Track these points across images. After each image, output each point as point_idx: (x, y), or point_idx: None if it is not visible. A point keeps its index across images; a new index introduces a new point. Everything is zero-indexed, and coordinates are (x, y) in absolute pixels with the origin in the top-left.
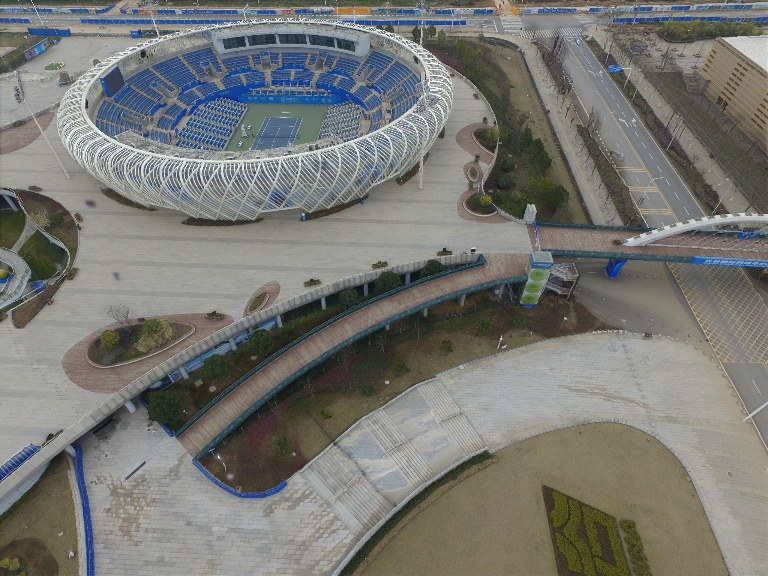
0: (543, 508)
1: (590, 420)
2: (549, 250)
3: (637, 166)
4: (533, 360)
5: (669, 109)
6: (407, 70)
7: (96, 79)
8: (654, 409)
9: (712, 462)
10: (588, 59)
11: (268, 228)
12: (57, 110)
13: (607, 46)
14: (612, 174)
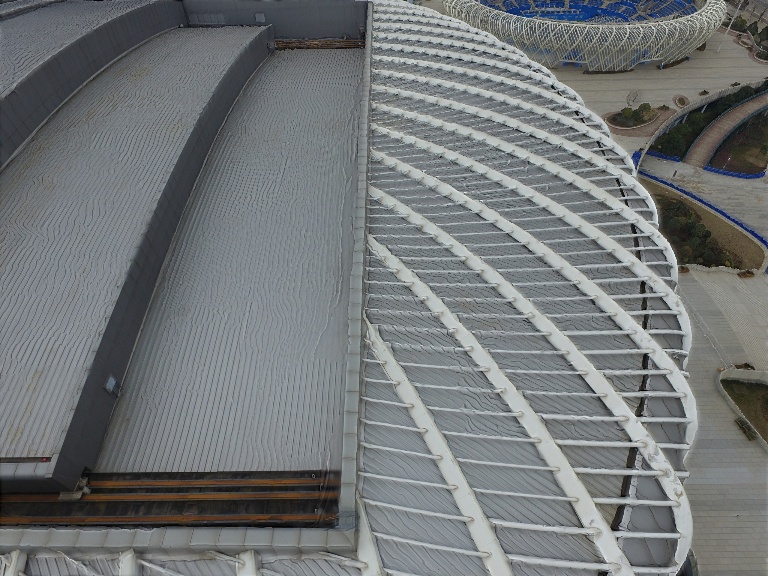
0: None
1: None
2: None
3: None
4: None
5: None
6: None
7: None
8: None
9: None
10: None
11: (642, 73)
12: None
13: None
14: None
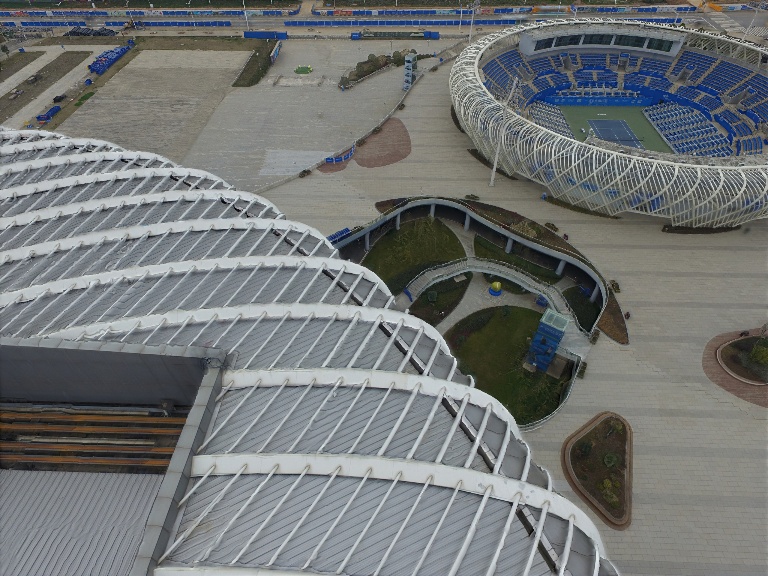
0: None
1: None
2: None
3: None
4: None
5: None
6: (744, 70)
7: None
8: None
9: None
10: None
11: (756, 235)
12: (398, 115)
13: None
14: None
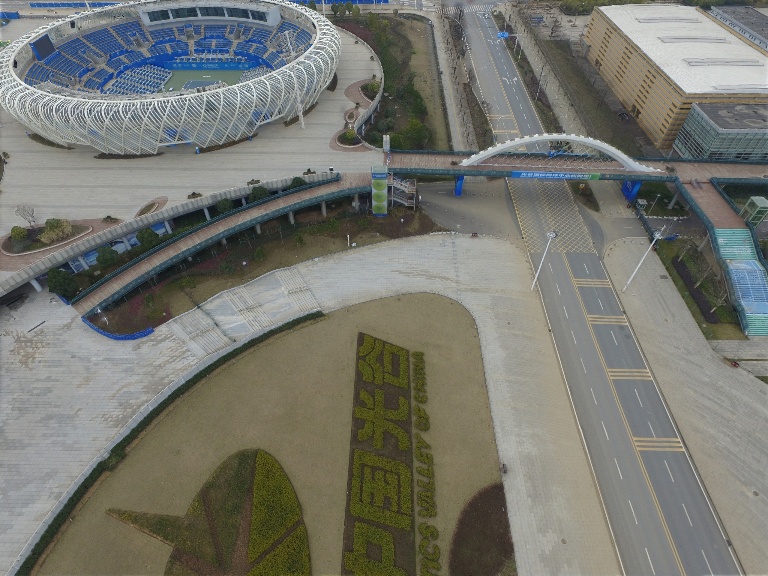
0: (355, 346)
1: (410, 292)
2: (395, 169)
3: (506, 114)
4: (376, 254)
5: (548, 69)
6: (309, 36)
7: (26, 44)
8: (463, 284)
9: (497, 316)
10: (491, 30)
11: (167, 159)
12: None
13: (506, 18)
14: (482, 120)
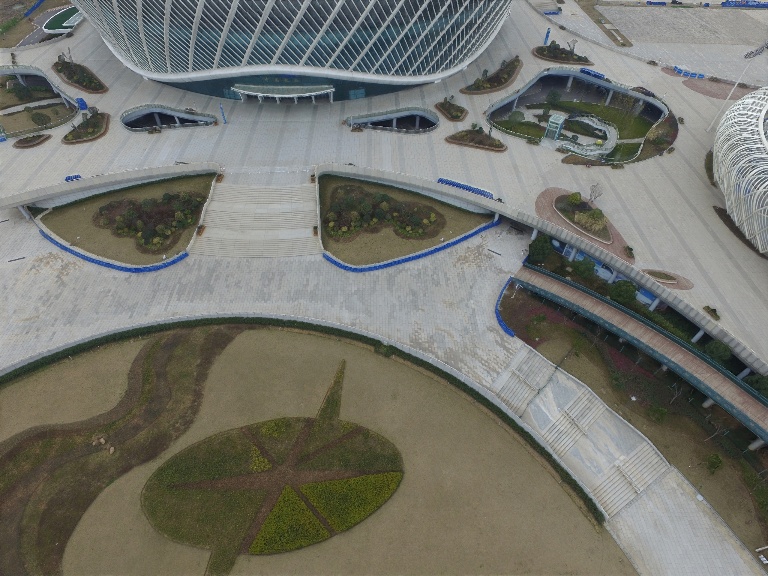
0: None
1: None
2: None
3: None
4: None
5: None
6: None
7: None
8: None
9: None
10: None
11: (759, 266)
12: None
13: None
14: None
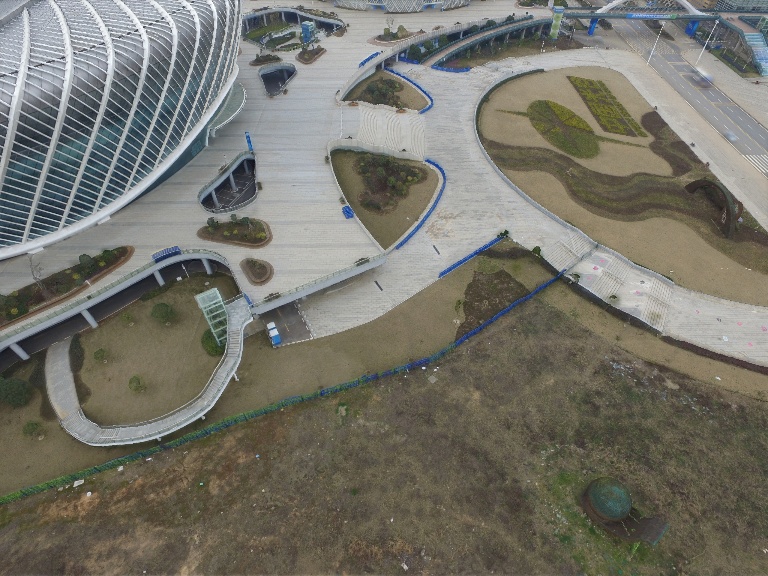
0: (567, 79)
1: None
2: None
3: (603, 4)
4: (557, 55)
5: None
6: None
7: None
8: (610, 63)
9: None
10: None
11: None
12: None
13: None
14: None
